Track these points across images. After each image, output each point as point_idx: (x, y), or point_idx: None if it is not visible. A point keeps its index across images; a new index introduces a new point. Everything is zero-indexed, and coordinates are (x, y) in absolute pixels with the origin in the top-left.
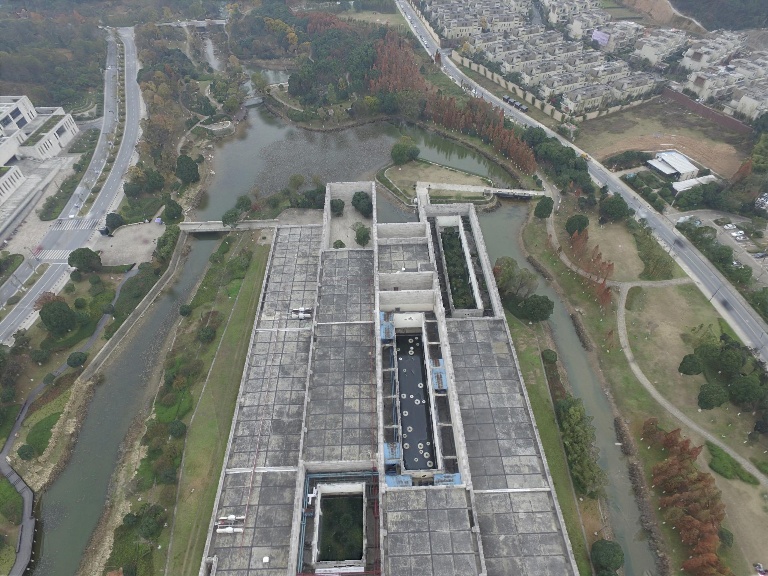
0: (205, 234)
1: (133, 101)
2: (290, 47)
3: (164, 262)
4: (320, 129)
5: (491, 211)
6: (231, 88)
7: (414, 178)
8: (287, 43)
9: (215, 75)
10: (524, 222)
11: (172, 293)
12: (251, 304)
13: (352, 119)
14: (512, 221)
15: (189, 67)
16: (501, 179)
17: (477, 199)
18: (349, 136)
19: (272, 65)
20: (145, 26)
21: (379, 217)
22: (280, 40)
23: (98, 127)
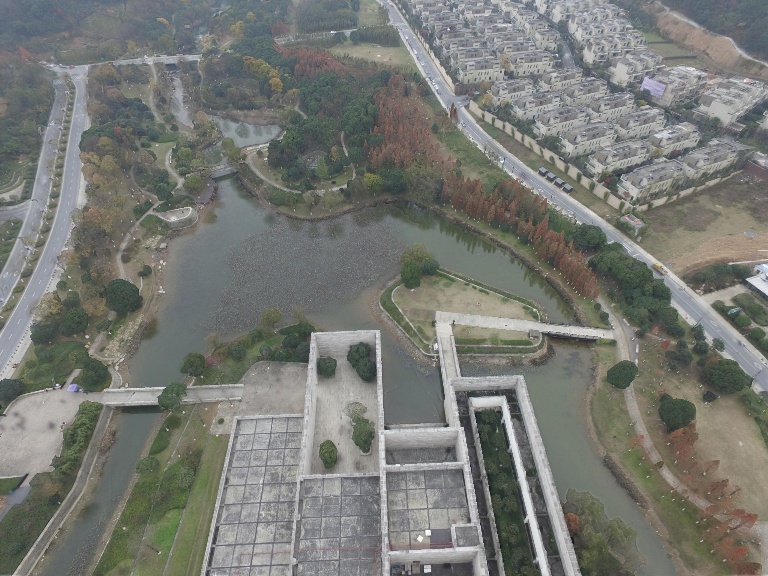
0: (139, 407)
1: (72, 175)
2: (273, 97)
3: (68, 476)
4: (307, 217)
5: (541, 364)
6: (195, 160)
7: (432, 305)
8: (270, 90)
9: (180, 134)
10: (590, 385)
11: (76, 533)
12: (191, 568)
13: (348, 202)
14: (572, 381)
15: (149, 123)
16: (543, 289)
17: (521, 345)
18: (344, 228)
19: (251, 117)
20: (100, 69)
21: (385, 374)
22: (261, 86)
23: (21, 216)
